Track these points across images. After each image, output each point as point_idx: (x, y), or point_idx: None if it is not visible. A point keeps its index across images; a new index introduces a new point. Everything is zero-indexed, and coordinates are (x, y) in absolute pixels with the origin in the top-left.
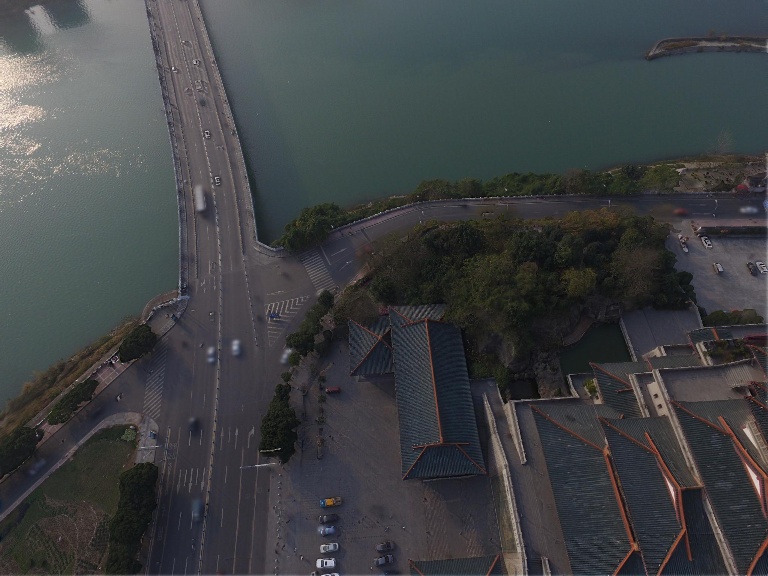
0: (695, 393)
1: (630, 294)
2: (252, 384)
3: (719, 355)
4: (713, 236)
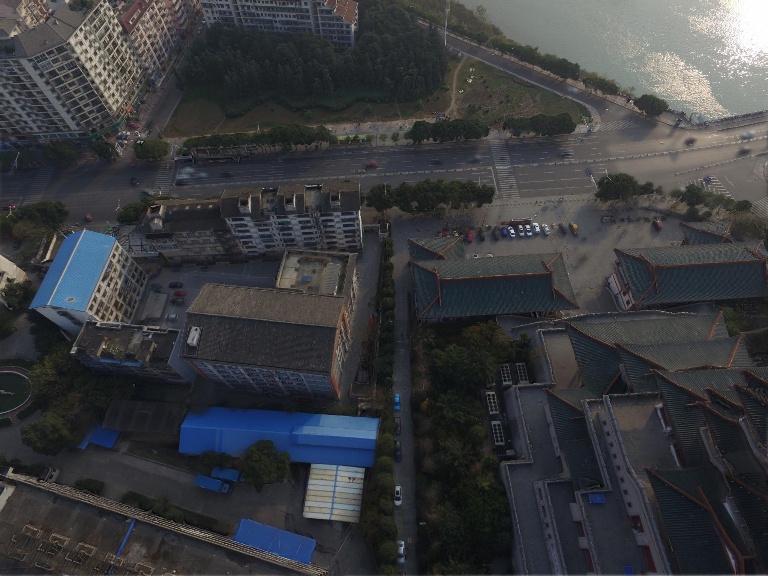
0: None
1: None
2: (643, 176)
3: None
4: None
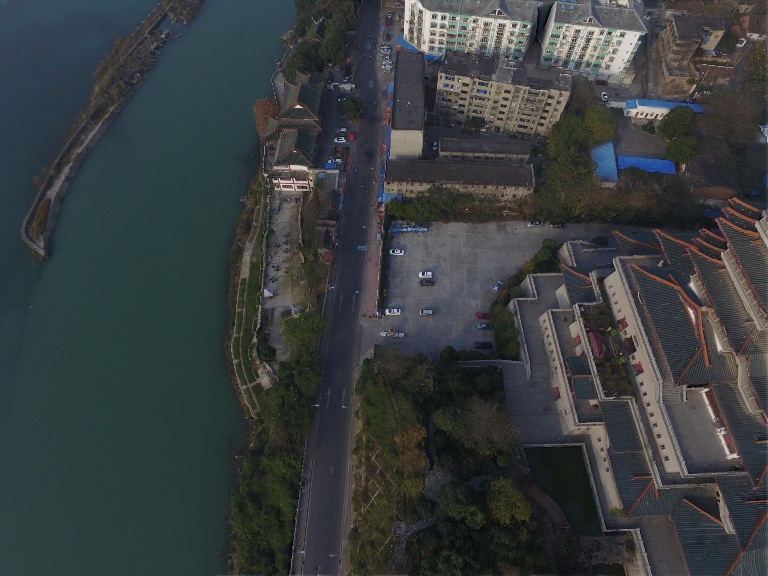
0: (699, 440)
1: None
2: None
3: None
4: (384, 303)
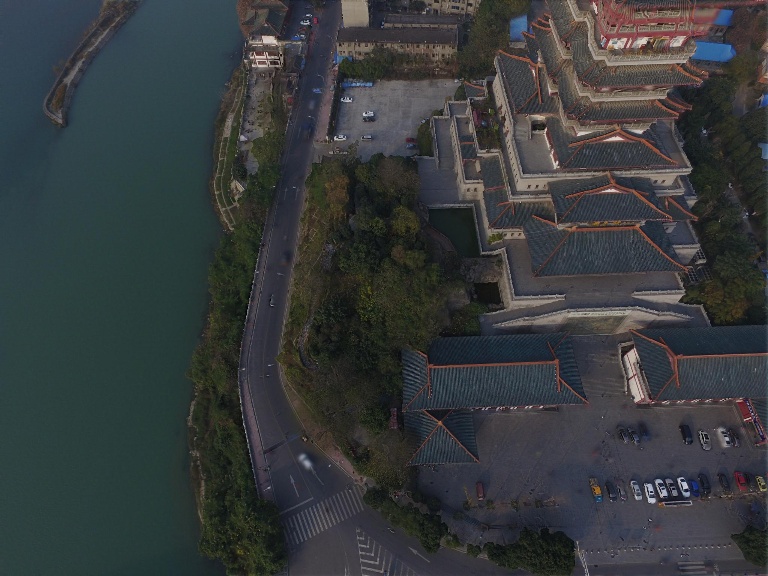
0: (536, 160)
1: None
2: None
3: (490, 144)
4: (334, 133)
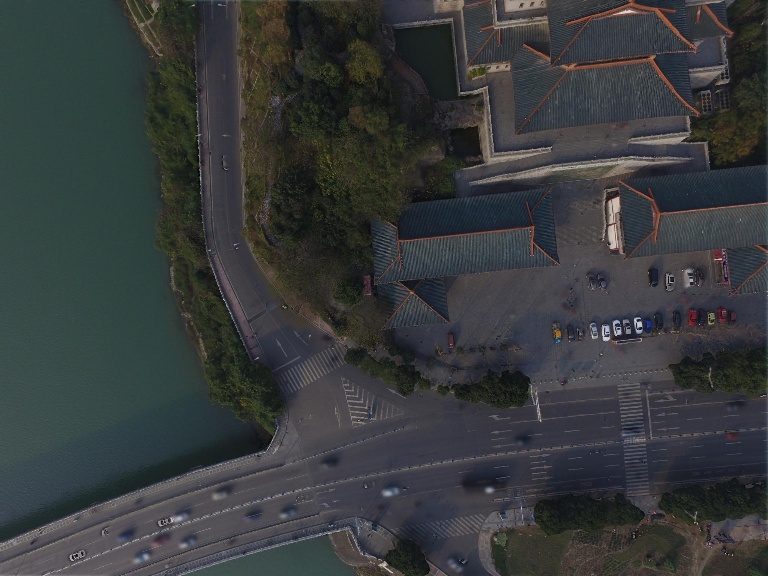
0: None
1: (378, 7)
2: (446, 426)
3: None
4: None
